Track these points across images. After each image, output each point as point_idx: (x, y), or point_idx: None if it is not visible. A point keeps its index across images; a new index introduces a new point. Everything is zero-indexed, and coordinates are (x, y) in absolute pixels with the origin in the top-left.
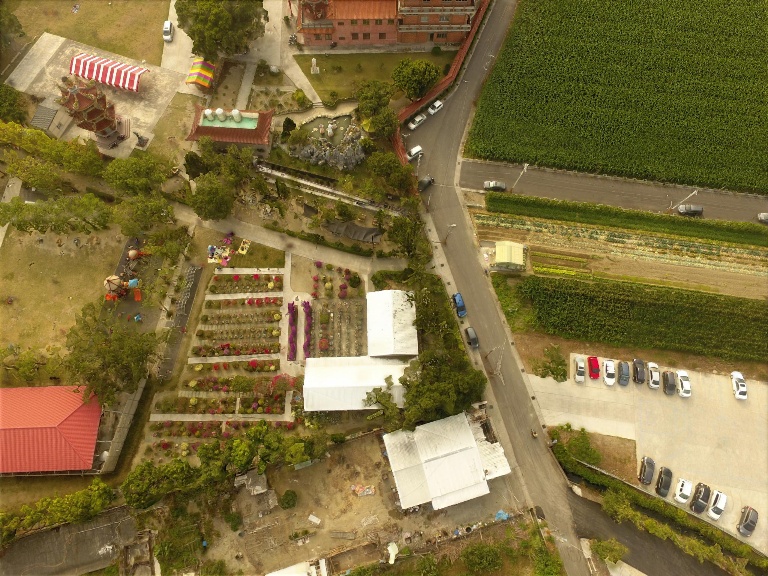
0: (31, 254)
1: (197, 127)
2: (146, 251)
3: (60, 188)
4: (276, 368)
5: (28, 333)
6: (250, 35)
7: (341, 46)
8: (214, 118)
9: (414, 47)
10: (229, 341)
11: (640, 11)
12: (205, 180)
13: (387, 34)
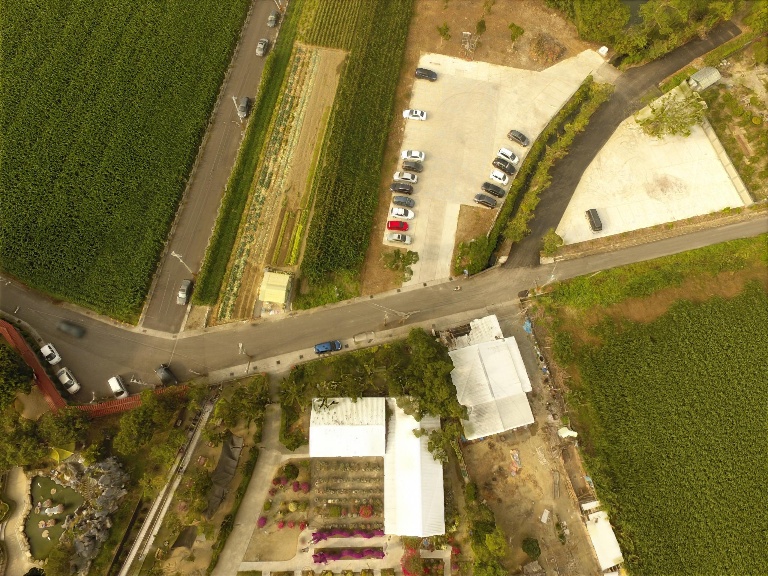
0: None
1: None
2: None
3: None
4: (392, 574)
5: None
6: None
7: None
8: None
9: None
10: None
11: None
12: None
13: None
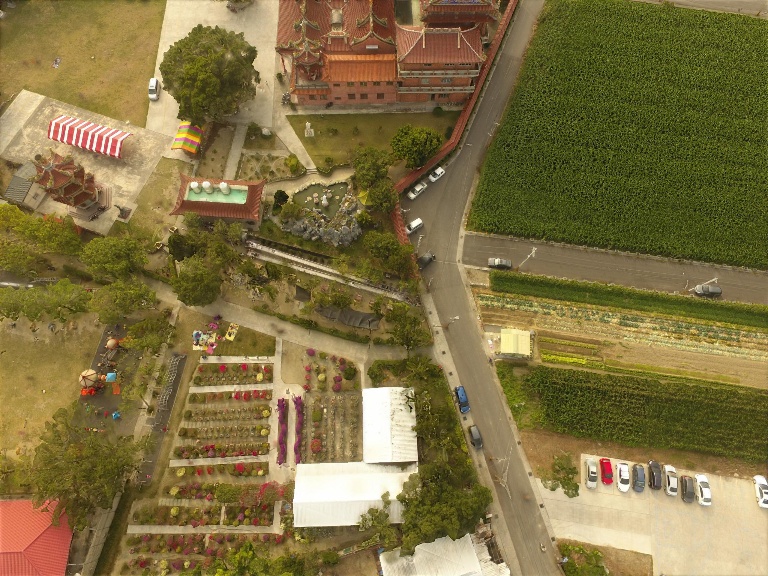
0: (3, 340)
1: (182, 201)
2: (125, 345)
3: (34, 270)
4: (264, 473)
5: None
6: (240, 99)
7: (337, 105)
8: (201, 190)
9: (414, 107)
10: (214, 440)
11: (652, 67)
12: (189, 266)
13: (386, 94)
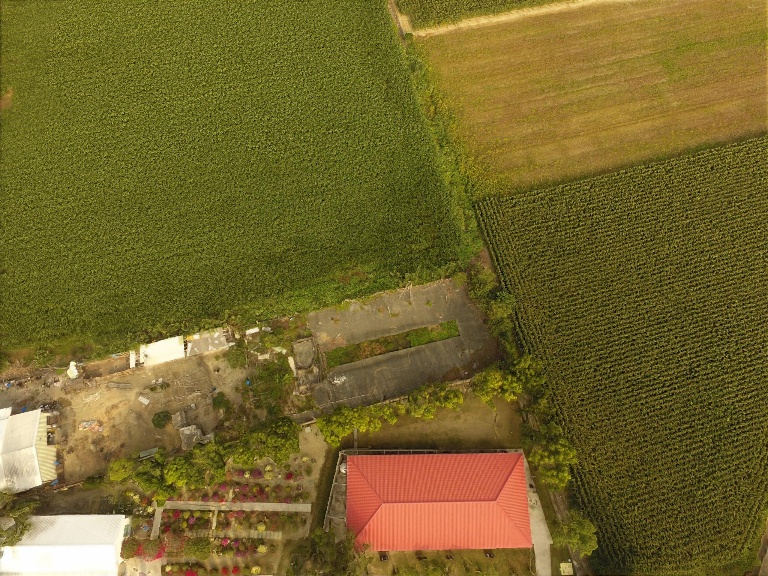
0: None
1: None
2: None
3: None
4: (164, 568)
5: None
6: None
7: None
8: None
9: None
10: None
11: None
12: None
13: None
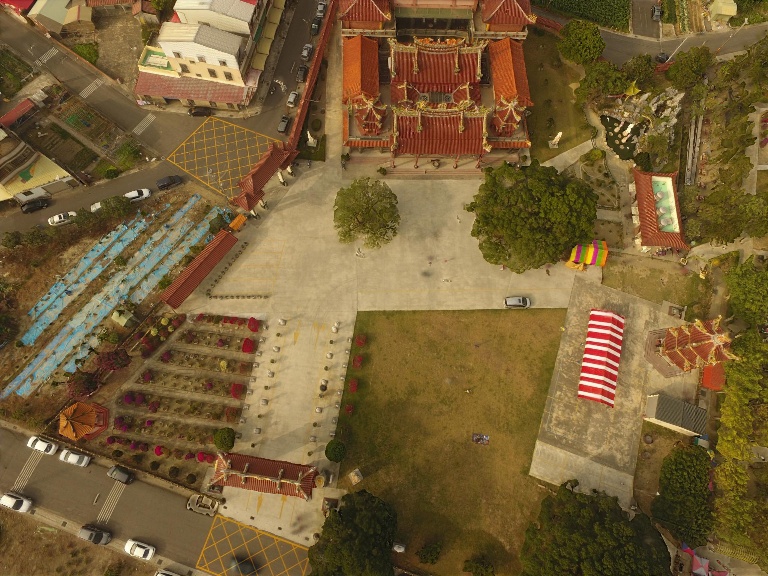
0: None
1: (680, 235)
2: None
3: None
4: None
5: None
6: None
7: None
8: None
9: None
10: None
11: None
12: (761, 208)
13: None
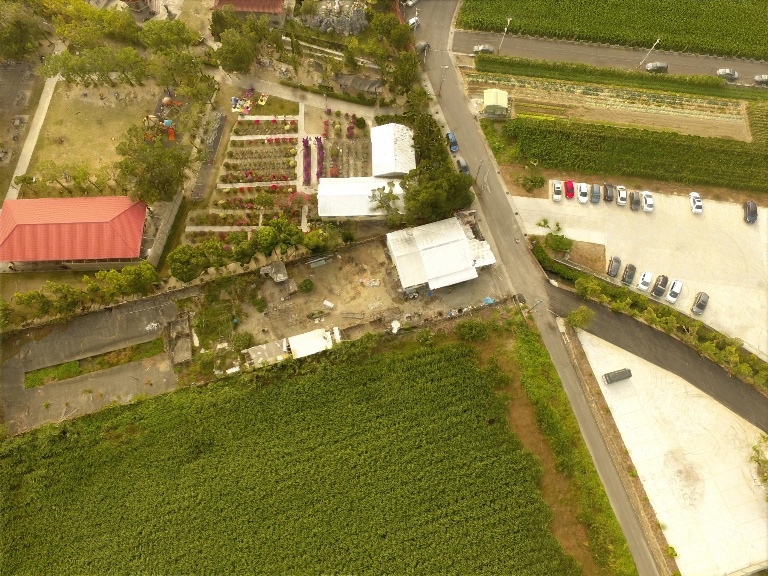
0: (77, 105)
1: None
2: (179, 92)
3: None
4: (293, 190)
5: (78, 165)
6: None
7: None
8: None
9: None
10: (252, 171)
11: None
12: (229, 33)
13: None
